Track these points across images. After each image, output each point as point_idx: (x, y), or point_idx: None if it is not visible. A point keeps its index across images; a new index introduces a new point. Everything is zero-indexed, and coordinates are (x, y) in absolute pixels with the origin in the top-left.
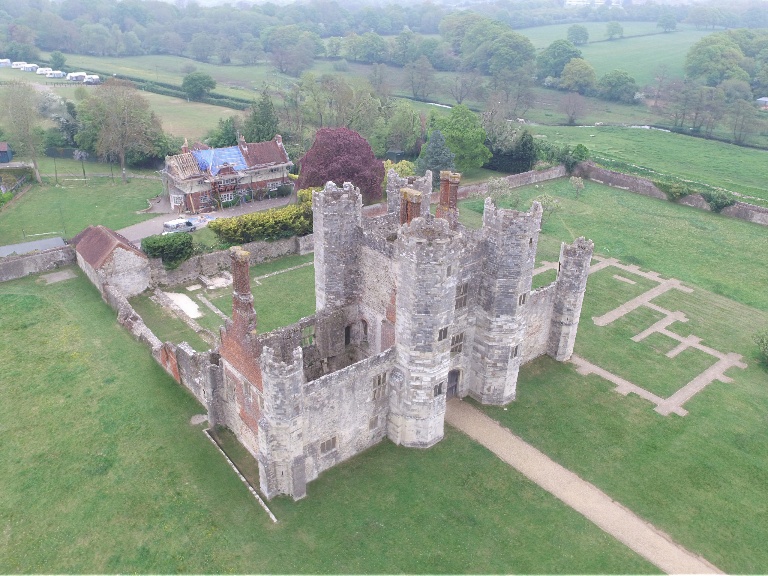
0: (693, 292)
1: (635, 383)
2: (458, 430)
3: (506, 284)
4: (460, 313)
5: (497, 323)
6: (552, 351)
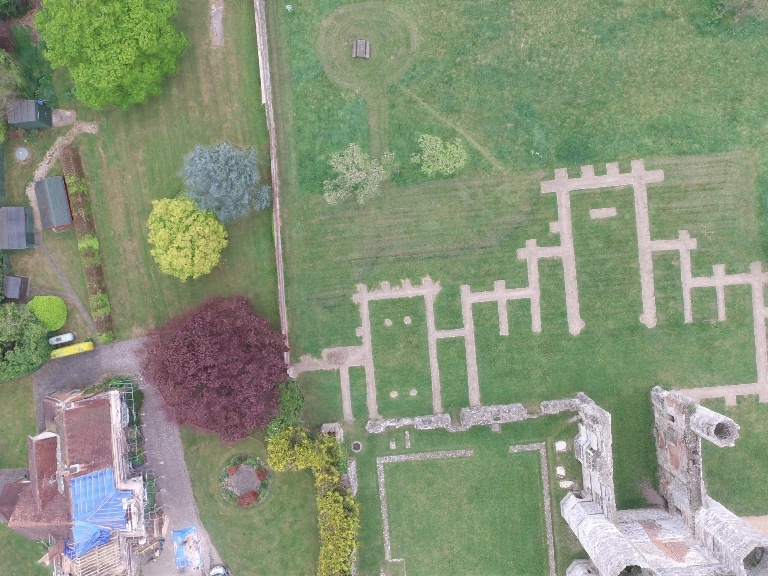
0: (666, 177)
1: (731, 384)
2: None
3: None
4: None
5: None
6: None
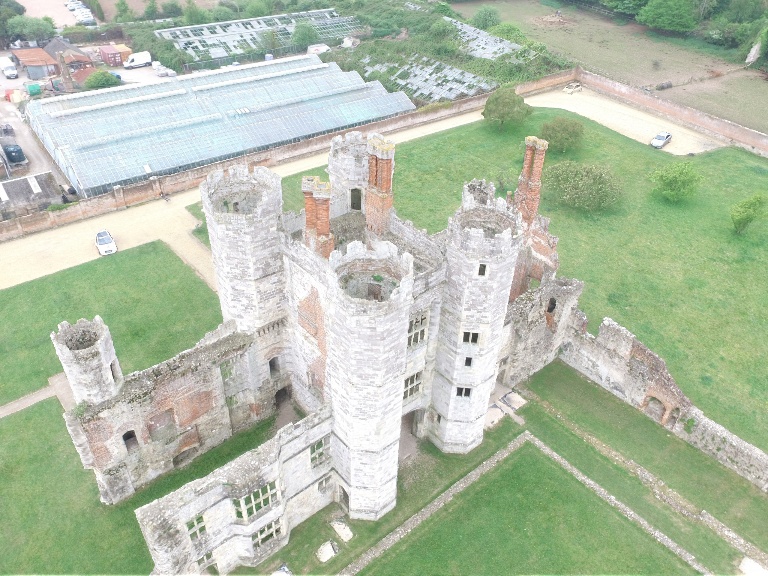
0: None
1: None
2: None
3: None
4: None
5: None
6: None
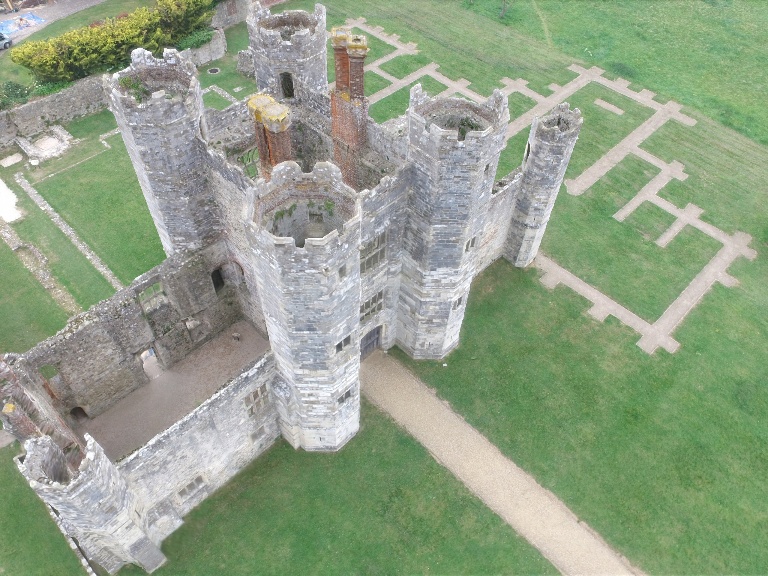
0: (696, 125)
1: (615, 298)
2: (380, 411)
3: (445, 231)
4: (375, 271)
5: (432, 277)
6: (510, 255)
